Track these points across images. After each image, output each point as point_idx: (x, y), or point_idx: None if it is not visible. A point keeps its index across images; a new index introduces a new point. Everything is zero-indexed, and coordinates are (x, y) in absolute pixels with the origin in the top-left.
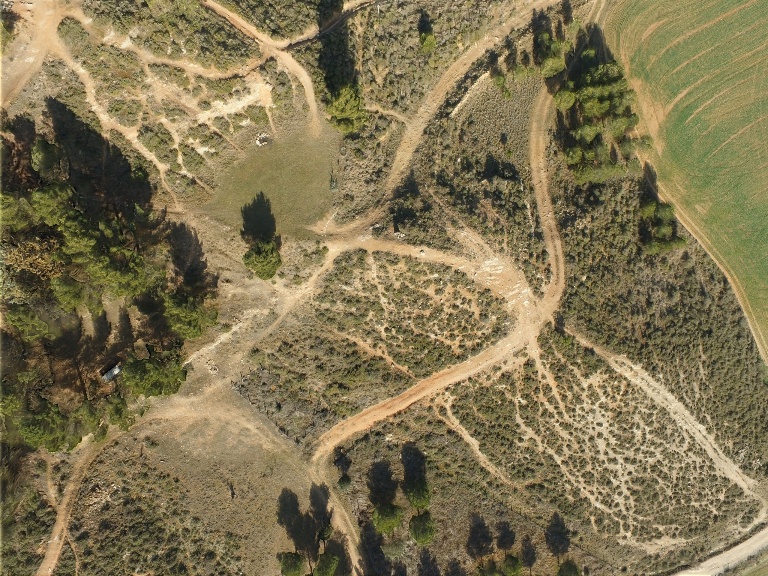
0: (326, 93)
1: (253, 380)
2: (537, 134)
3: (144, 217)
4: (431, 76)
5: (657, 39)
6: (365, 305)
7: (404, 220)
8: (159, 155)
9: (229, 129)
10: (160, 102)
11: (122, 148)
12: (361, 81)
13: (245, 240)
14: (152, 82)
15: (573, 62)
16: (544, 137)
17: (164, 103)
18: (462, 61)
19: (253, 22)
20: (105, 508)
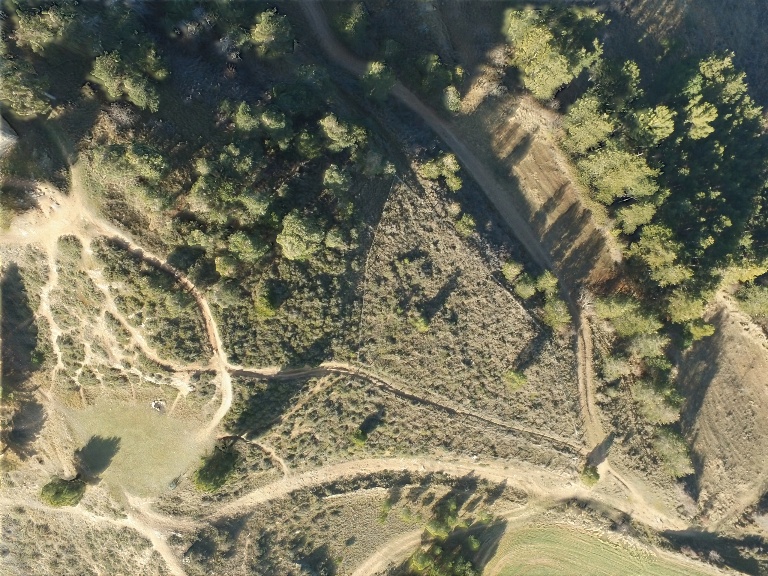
0: (234, 422)
1: (5, 522)
2: (381, 557)
3: (4, 394)
4: (342, 456)
5: (541, 570)
6: (123, 567)
7: (200, 553)
8: (64, 358)
9: (137, 383)
10: (95, 334)
11: (41, 331)
12: (276, 427)
13: (75, 457)
14: (100, 321)
15: (463, 530)
16: (384, 563)
17: (97, 338)
18: (379, 462)
19: (224, 339)
20: None
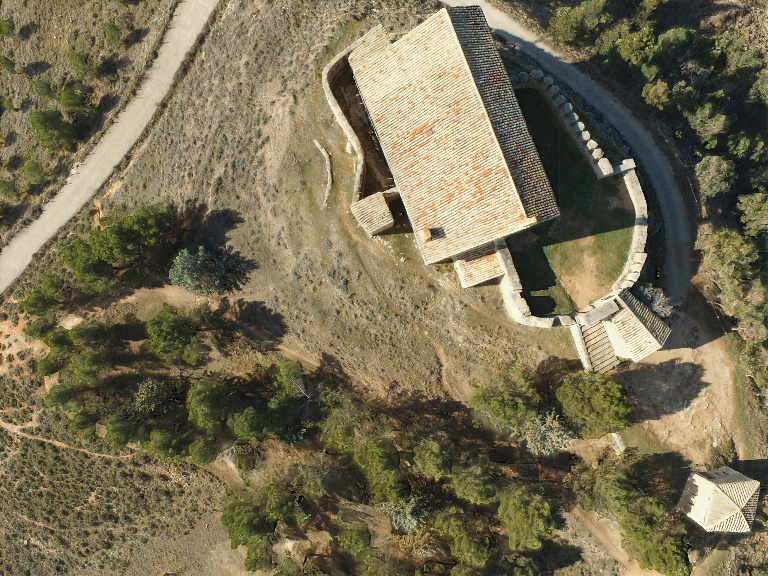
0: None
1: None
2: None
3: None
4: None
5: None
6: None
7: None
8: None
9: None
10: None
11: None
12: None
13: None
14: None
15: None
16: None
17: None
18: None
19: None
20: (165, 478)
